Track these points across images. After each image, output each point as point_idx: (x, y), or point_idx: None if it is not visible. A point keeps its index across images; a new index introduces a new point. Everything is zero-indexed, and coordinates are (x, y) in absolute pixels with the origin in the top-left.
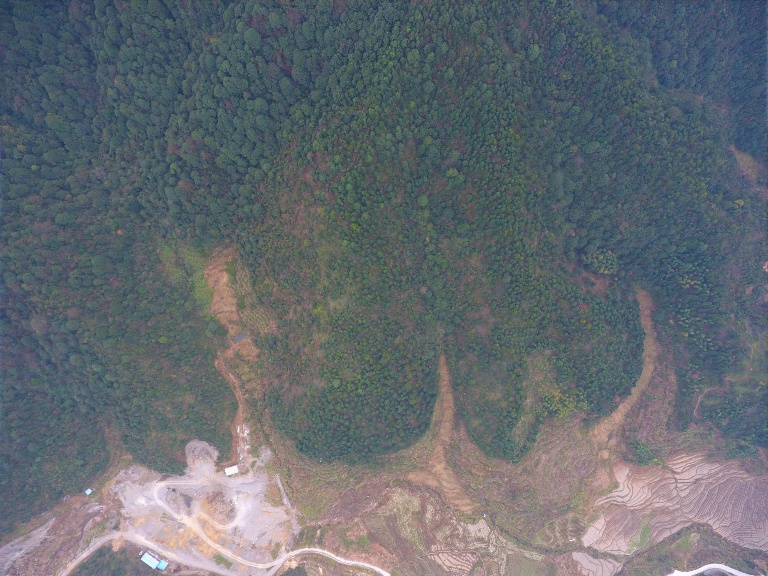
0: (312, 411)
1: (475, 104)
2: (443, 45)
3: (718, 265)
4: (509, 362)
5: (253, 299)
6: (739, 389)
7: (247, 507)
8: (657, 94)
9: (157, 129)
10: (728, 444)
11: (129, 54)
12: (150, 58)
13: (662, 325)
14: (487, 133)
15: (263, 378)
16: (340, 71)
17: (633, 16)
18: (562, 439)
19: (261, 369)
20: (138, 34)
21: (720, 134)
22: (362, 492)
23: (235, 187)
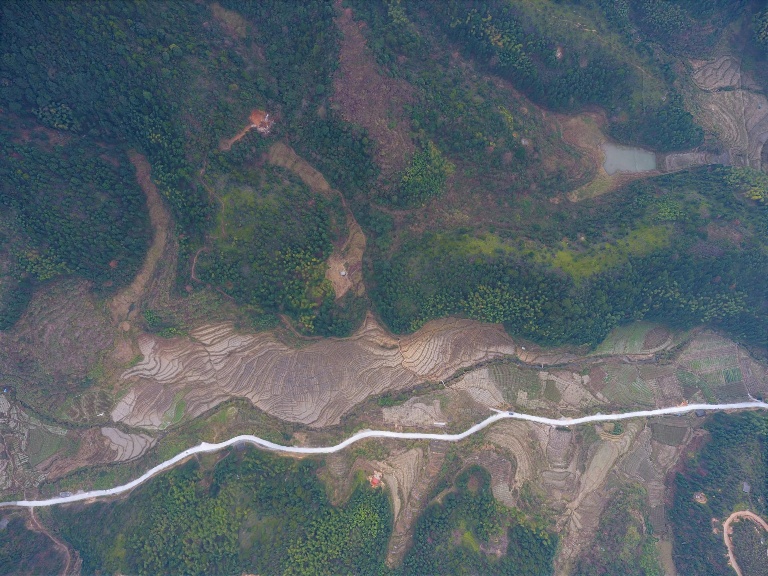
0: None
1: None
2: None
3: None
4: None
5: None
6: (222, 247)
7: None
8: None
9: None
10: (238, 309)
11: None
12: None
13: (159, 189)
14: None
15: None
16: None
17: None
18: (68, 308)
19: None
20: None
21: None
22: None
23: None
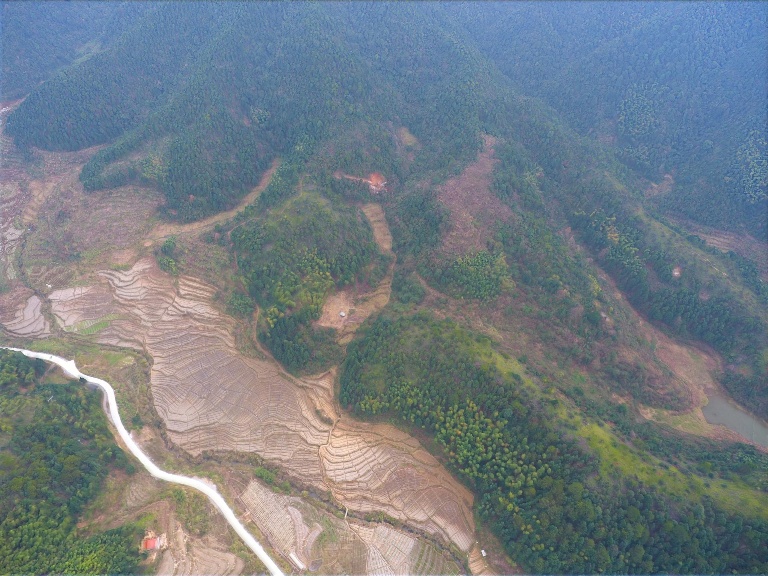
0: None
1: None
2: None
3: None
4: None
5: None
6: (271, 221)
7: None
8: None
9: None
10: None
11: None
12: None
13: None
14: (236, 6)
15: None
16: None
17: None
18: (134, 207)
19: None
20: None
21: None
22: None
23: None
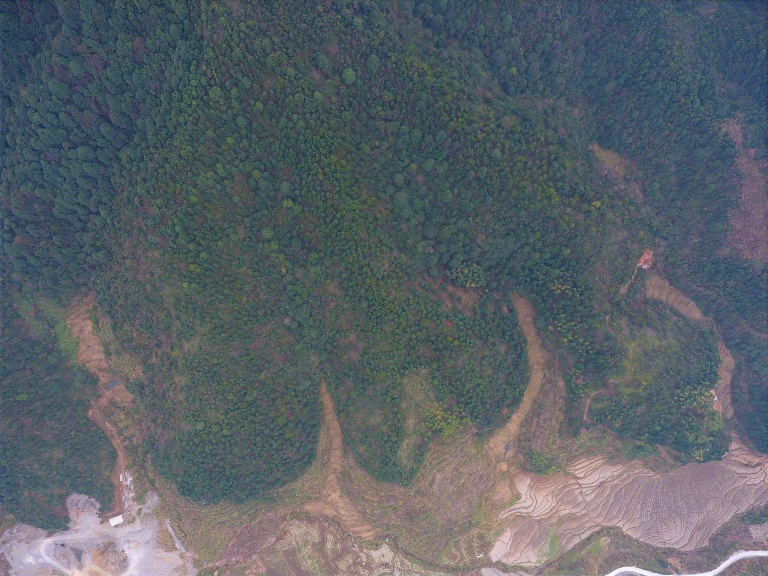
0: (183, 455)
1: (290, 135)
2: (244, 80)
3: (585, 268)
4: (382, 386)
5: (117, 346)
6: (624, 390)
7: (139, 555)
8: (492, 104)
9: None
10: (624, 445)
11: None
12: None
13: (544, 331)
14: (309, 162)
15: (141, 423)
16: (153, 113)
17: (461, 28)
18: (455, 456)
19: (138, 414)
20: None
21: None
22: (258, 528)
23: (78, 236)
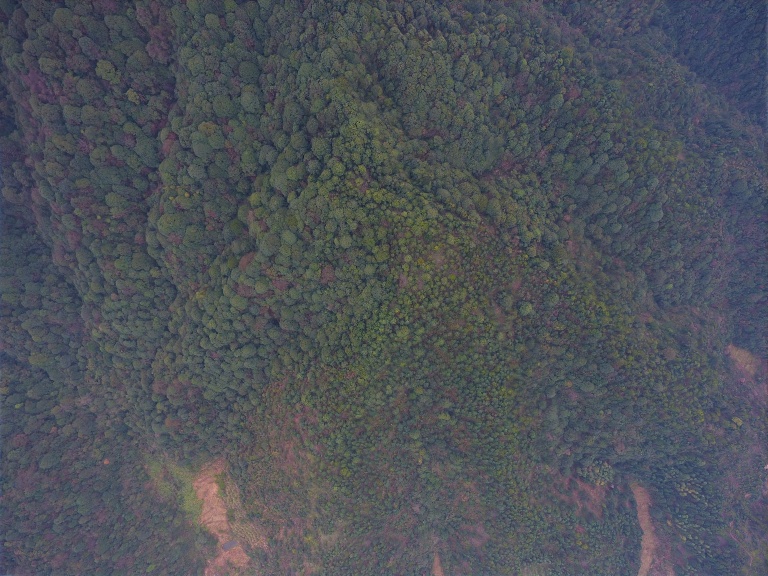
0: None
1: (466, 369)
2: (433, 322)
3: (716, 478)
4: None
5: (243, 515)
6: None
7: None
8: (653, 329)
9: (143, 362)
10: None
11: (113, 307)
12: (135, 307)
13: (660, 522)
14: (479, 392)
15: None
16: (329, 330)
17: (628, 249)
18: None
19: (252, 575)
20: (122, 290)
21: (717, 357)
22: None
23: (223, 416)
